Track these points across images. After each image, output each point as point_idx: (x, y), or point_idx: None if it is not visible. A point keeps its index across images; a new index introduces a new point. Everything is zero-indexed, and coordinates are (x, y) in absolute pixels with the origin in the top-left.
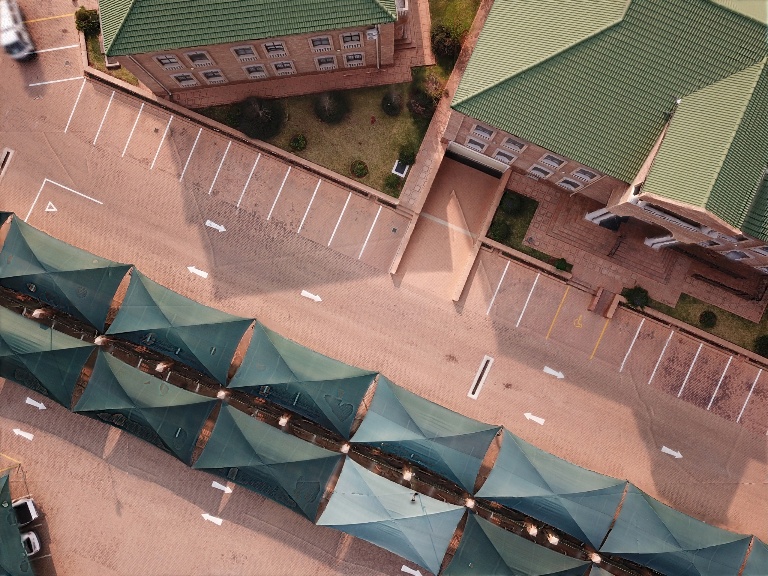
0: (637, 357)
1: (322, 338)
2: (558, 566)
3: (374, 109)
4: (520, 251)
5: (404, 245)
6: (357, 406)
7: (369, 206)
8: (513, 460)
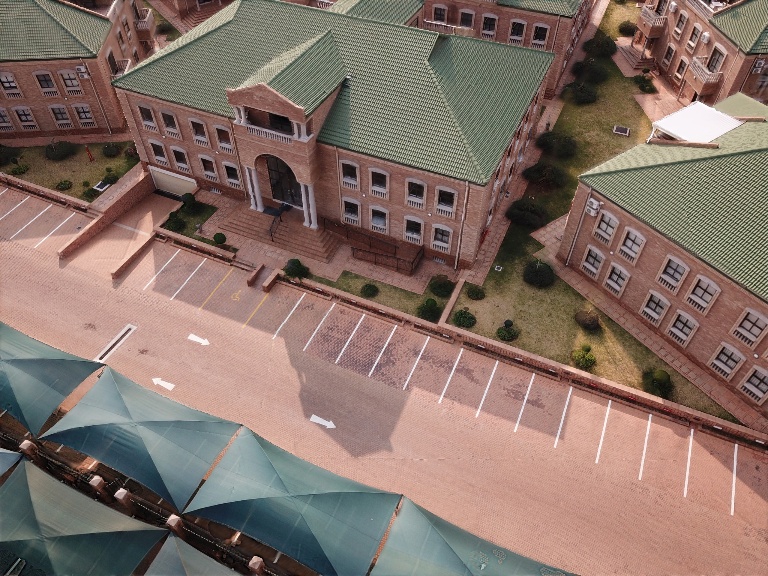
0: (293, 326)
1: None
2: (112, 526)
3: (96, 154)
4: (189, 237)
5: (80, 233)
6: None
7: (64, 212)
8: (101, 392)
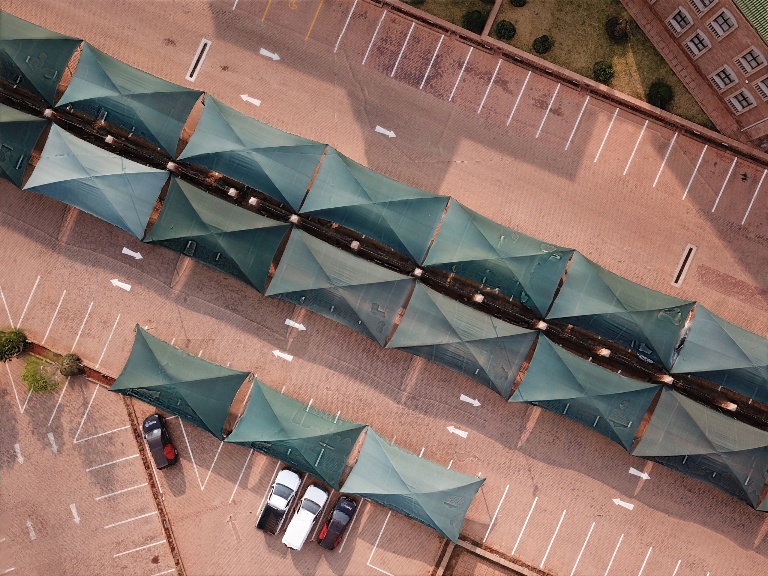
0: (351, 37)
1: (43, 23)
2: (255, 224)
3: None
4: None
5: None
6: (61, 72)
7: None
8: (211, 121)
